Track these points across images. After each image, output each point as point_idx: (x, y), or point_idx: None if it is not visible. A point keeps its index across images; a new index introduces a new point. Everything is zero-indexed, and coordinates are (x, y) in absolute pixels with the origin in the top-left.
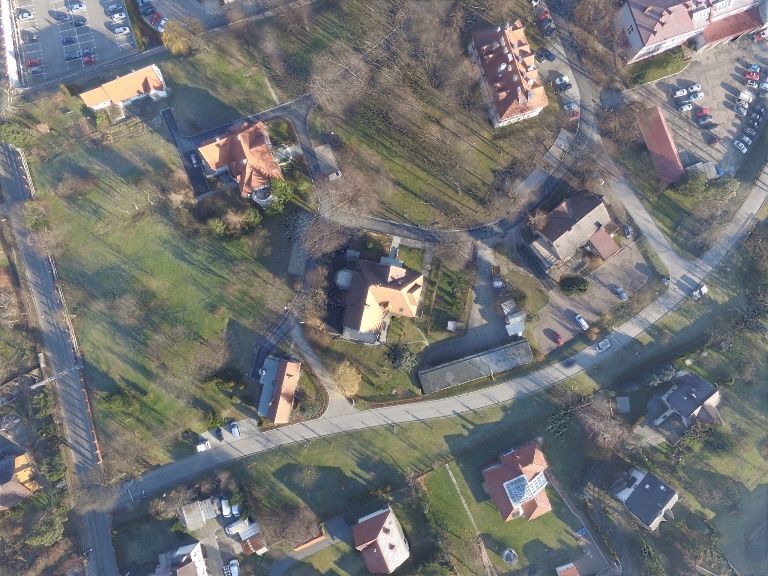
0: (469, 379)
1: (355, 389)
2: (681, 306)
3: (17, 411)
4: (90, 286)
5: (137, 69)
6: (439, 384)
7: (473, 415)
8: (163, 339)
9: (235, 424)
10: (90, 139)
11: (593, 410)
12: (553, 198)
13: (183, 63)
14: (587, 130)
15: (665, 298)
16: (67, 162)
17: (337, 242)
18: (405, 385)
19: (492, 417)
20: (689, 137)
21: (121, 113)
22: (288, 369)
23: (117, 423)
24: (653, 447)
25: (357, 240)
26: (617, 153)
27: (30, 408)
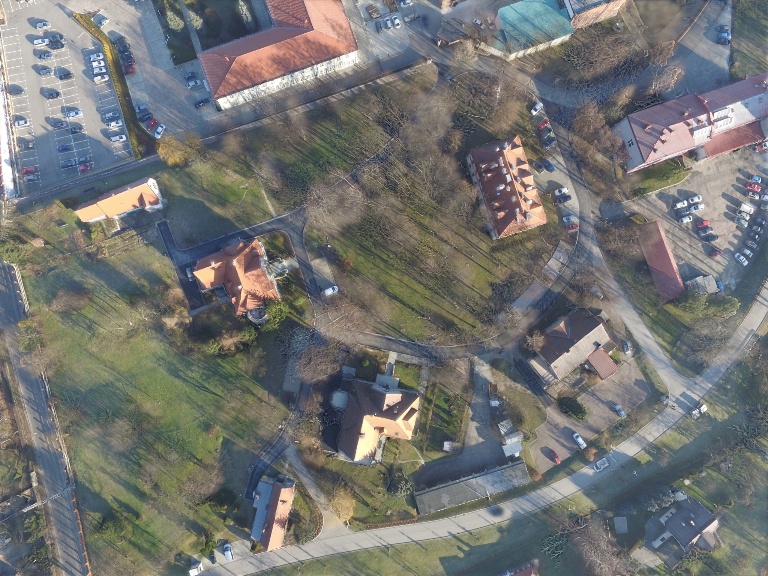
0: (465, 501)
1: (349, 515)
2: (680, 424)
3: (9, 530)
4: (83, 404)
5: (133, 183)
6: (434, 506)
7: (469, 536)
8: (156, 459)
9: (228, 547)
10: (85, 252)
11: (590, 533)
12: (551, 313)
13: (179, 174)
14: (586, 242)
15: (664, 416)
16: (61, 276)
17: (333, 359)
18: (400, 505)
19: (488, 538)
20: (689, 249)
21: (116, 226)
22: (282, 495)
23: (109, 545)
24: (651, 569)
25: (353, 358)
26: (616, 266)
27: (21, 534)
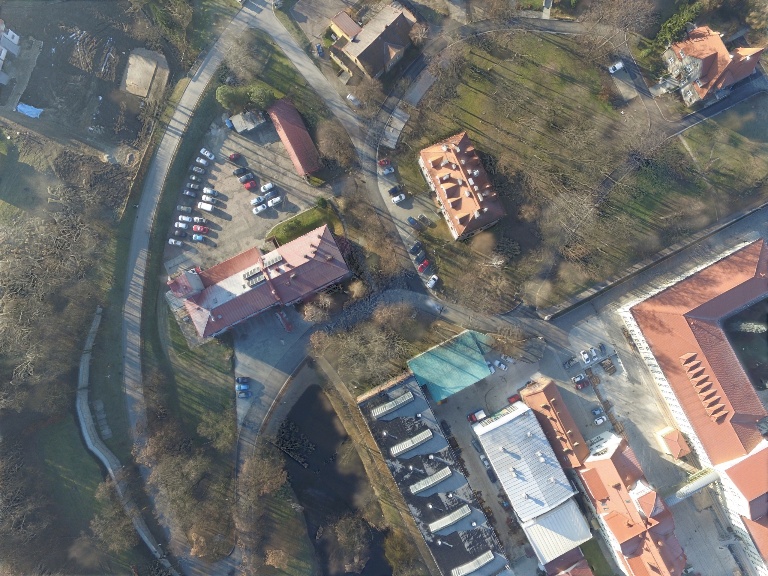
0: None
1: None
2: None
3: None
4: None
5: None
6: None
7: None
8: None
9: None
10: None
11: None
12: (398, 73)
13: None
14: (368, 150)
15: None
16: None
17: (604, 4)
18: None
19: None
20: (261, 160)
21: None
22: None
23: None
24: None
25: (588, 4)
26: (336, 129)
27: None
